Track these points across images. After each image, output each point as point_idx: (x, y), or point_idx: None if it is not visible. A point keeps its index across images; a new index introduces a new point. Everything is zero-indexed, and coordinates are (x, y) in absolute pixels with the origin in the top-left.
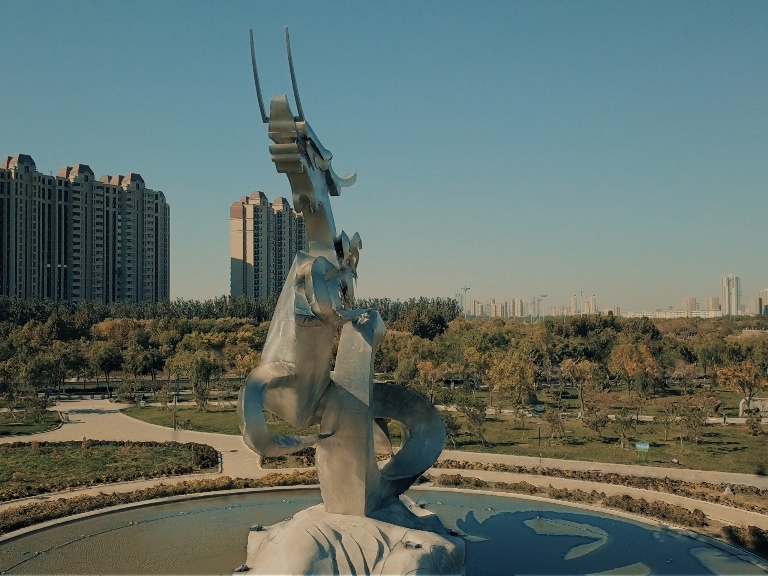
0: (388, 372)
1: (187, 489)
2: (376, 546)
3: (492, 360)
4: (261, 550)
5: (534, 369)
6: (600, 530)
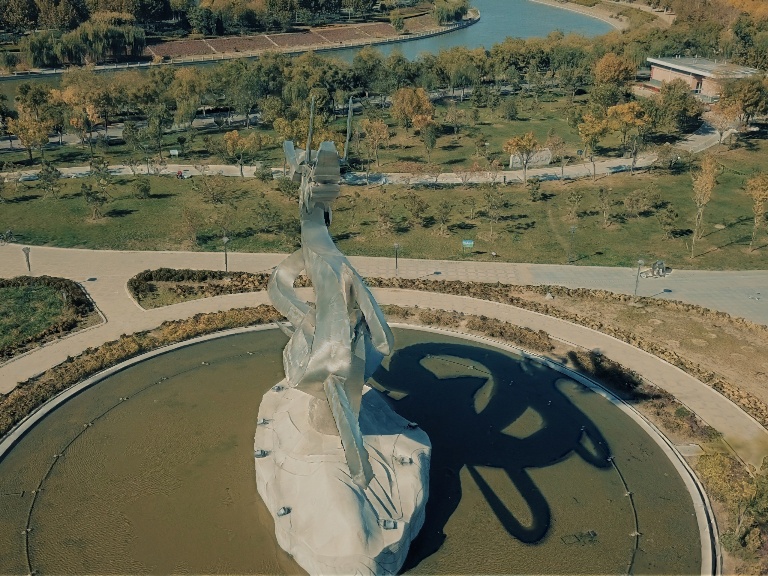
0: (157, 105)
1: (103, 363)
2: (385, 472)
3: (299, 129)
4: (279, 480)
5: (343, 140)
6: (482, 366)
